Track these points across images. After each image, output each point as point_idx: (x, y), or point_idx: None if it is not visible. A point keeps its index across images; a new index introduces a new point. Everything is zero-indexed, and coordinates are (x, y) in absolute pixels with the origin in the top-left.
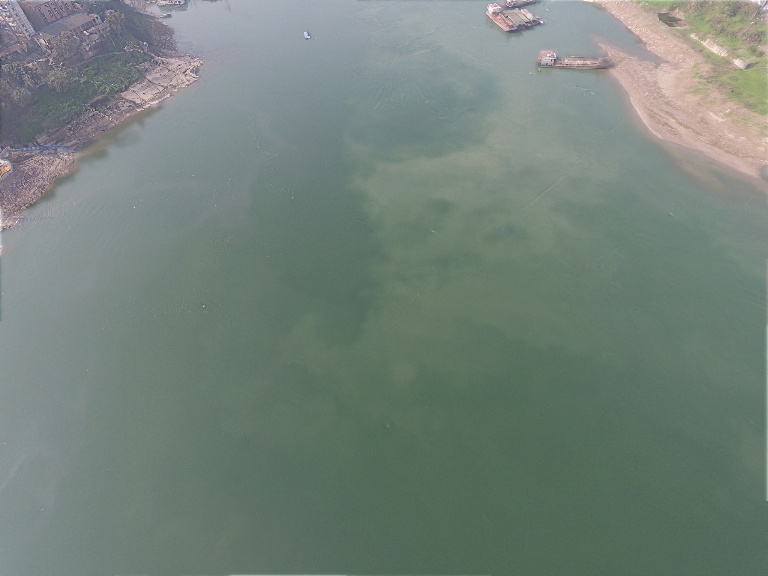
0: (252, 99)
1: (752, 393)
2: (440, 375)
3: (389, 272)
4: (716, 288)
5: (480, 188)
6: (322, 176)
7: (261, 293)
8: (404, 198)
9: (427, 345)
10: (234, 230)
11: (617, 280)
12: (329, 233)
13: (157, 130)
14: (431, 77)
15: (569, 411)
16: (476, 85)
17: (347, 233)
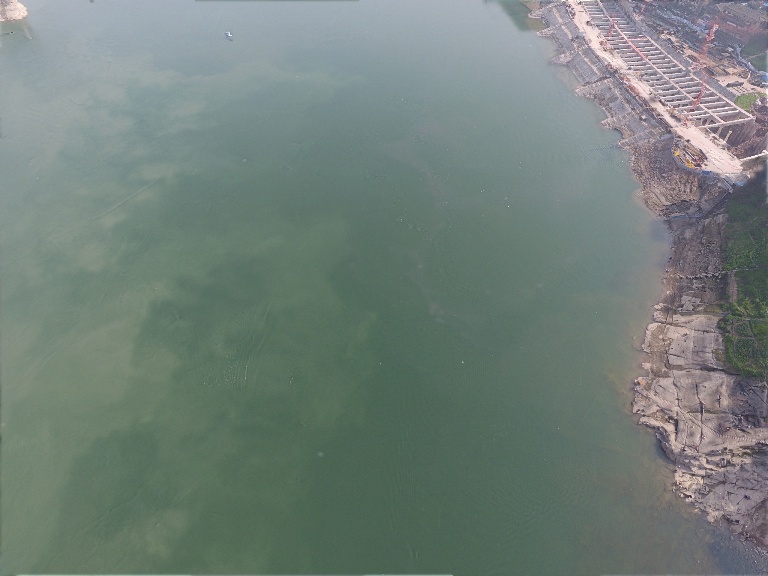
0: (480, 335)
1: (113, 93)
2: (266, 89)
3: (285, 118)
4: (71, 133)
5: (183, 205)
6: (344, 208)
7: (372, 105)
8: (262, 184)
9: (270, 99)
10: (412, 145)
11: (130, 135)
12: (330, 144)
13: (587, 258)
14: (150, 396)
15: (208, 84)
16: (85, 359)
17: (314, 139)
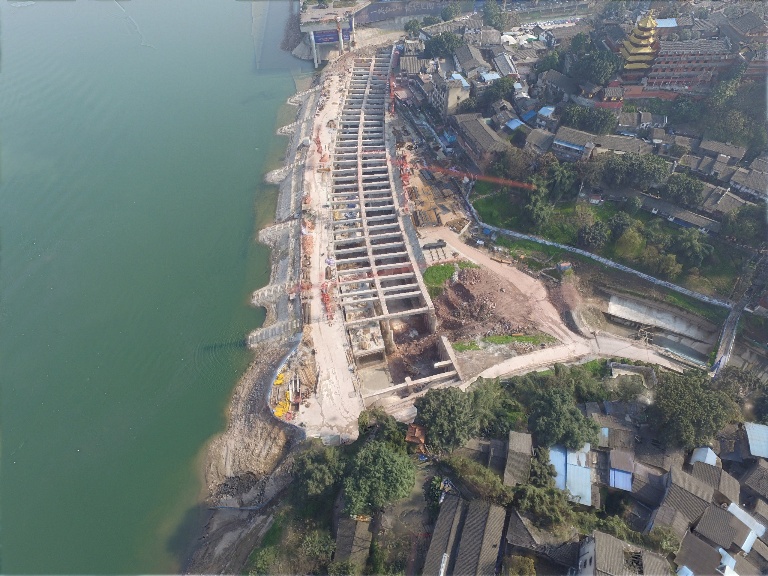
0: None
1: None
2: None
3: None
4: None
5: None
6: None
7: None
8: None
9: None
10: None
11: None
12: None
13: None
14: None
15: None
16: None
17: None
